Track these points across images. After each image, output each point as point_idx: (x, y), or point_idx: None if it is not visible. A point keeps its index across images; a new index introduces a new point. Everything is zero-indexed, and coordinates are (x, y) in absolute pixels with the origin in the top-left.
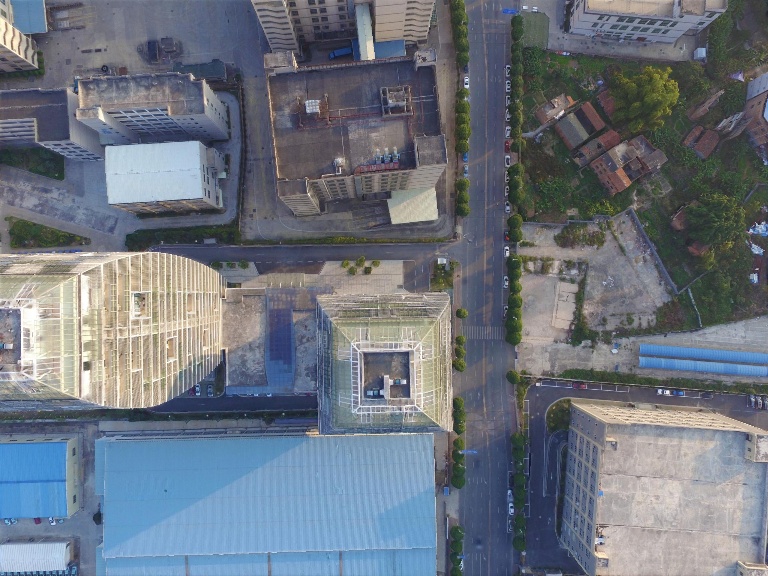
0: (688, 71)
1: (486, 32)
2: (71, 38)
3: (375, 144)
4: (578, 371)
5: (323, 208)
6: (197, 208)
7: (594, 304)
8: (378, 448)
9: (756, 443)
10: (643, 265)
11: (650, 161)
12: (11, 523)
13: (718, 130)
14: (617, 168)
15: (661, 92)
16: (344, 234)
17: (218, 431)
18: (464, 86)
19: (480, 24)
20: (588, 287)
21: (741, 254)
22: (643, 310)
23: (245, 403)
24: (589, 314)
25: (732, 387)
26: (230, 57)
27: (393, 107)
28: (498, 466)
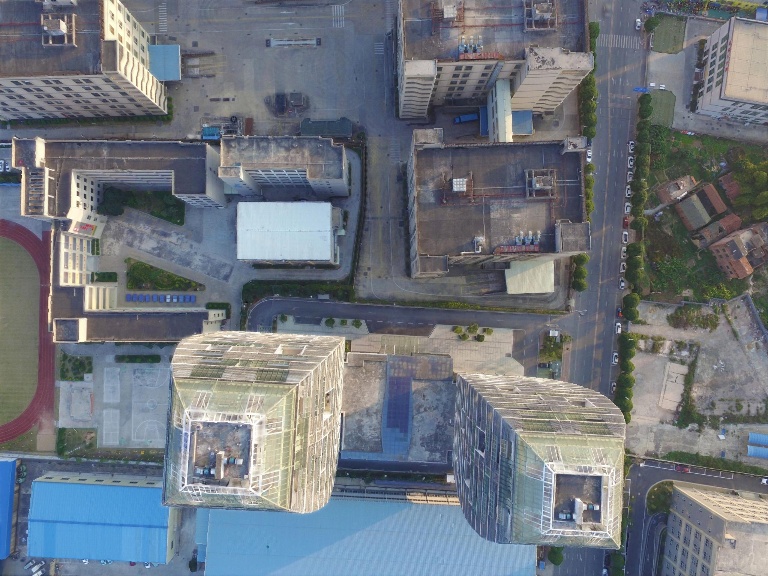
0: None
1: (611, 106)
2: (201, 86)
3: (516, 225)
4: (683, 454)
5: None
6: (314, 263)
7: (703, 387)
8: None
9: None
10: (755, 352)
11: None
12: (106, 563)
13: None
14: (742, 256)
15: None
16: (456, 299)
17: None
18: (586, 159)
19: (606, 98)
20: (698, 370)
21: None
22: (752, 397)
23: (346, 461)
24: (698, 397)
25: None
26: (355, 115)
27: (537, 190)
28: None
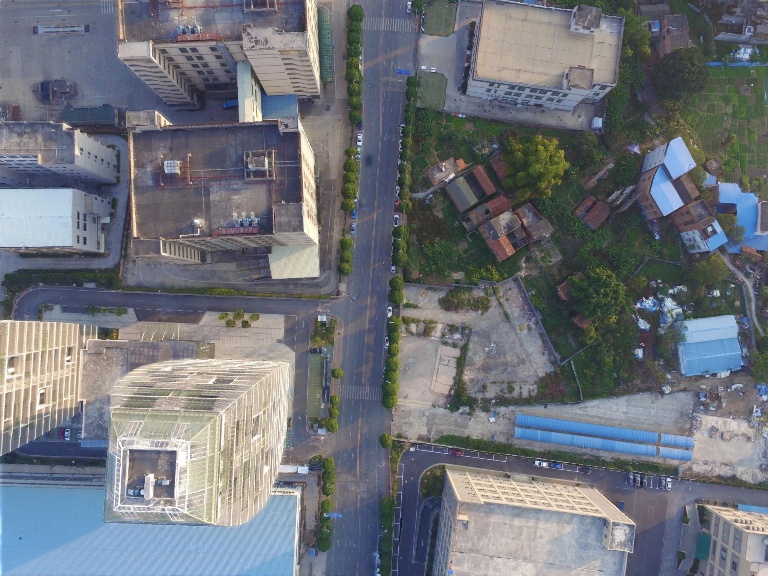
0: (582, 141)
1: (383, 90)
2: None
3: (236, 207)
4: (454, 438)
5: (204, 259)
6: (78, 251)
7: (475, 370)
8: None
9: (611, 531)
10: (527, 333)
11: (535, 231)
12: None
13: (608, 202)
14: (498, 237)
15: (544, 164)
16: (226, 285)
17: (86, 477)
18: (357, 143)
19: (377, 81)
20: (470, 353)
21: (627, 328)
22: (525, 379)
23: None
24: (469, 380)
25: (610, 463)
26: (124, 101)
27: (255, 171)
28: (368, 529)
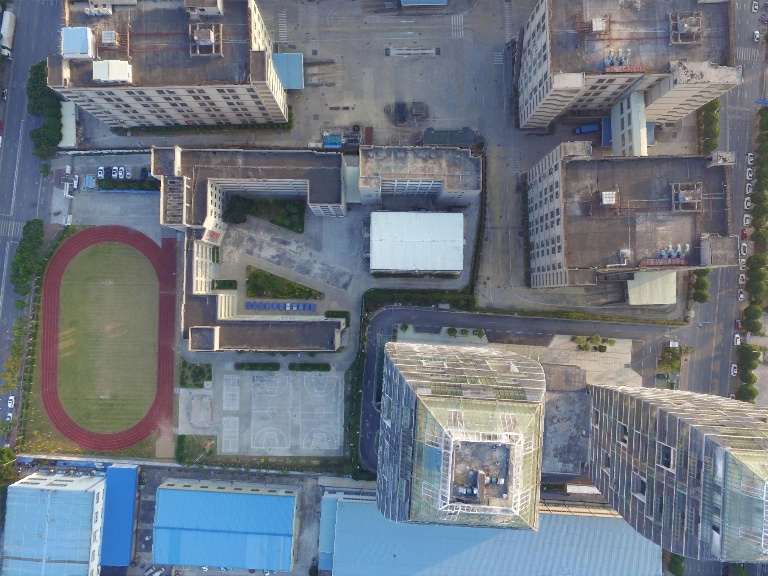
0: None
1: (730, 118)
2: (320, 94)
3: (661, 238)
4: None
5: None
6: None
7: None
8: (606, 530)
9: None
10: None
11: None
12: (226, 570)
13: None
14: None
15: None
16: (575, 309)
17: None
18: None
19: (724, 110)
20: None
21: None
22: None
23: None
24: None
25: None
26: (475, 124)
27: (684, 203)
28: None
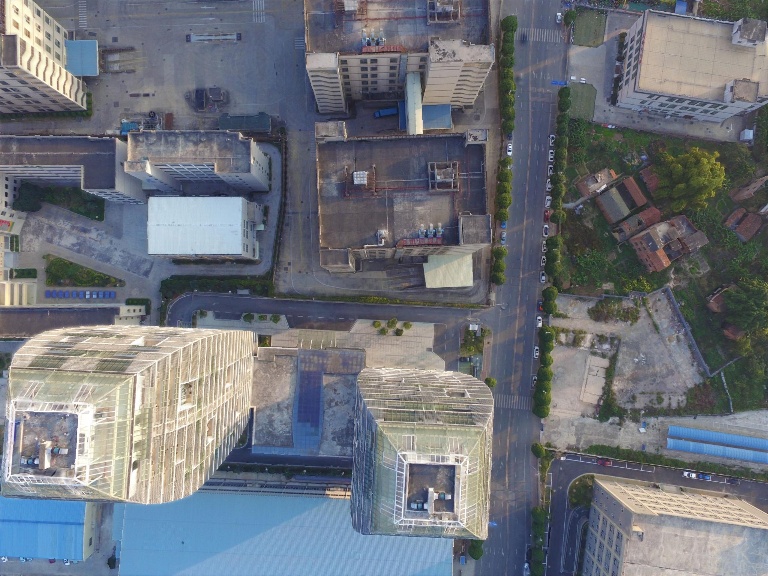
0: (734, 153)
1: (532, 100)
2: (121, 81)
3: (419, 217)
4: (604, 448)
5: (358, 267)
6: (233, 258)
7: (624, 381)
8: None
9: None
10: (676, 344)
11: (691, 242)
12: (26, 560)
13: (761, 214)
14: (657, 248)
15: (707, 176)
16: (377, 293)
17: (238, 482)
18: (507, 153)
19: (527, 92)
20: (619, 363)
21: None
22: (674, 390)
23: (267, 456)
24: (618, 390)
25: (760, 475)
26: (276, 109)
27: (440, 182)
28: (516, 538)
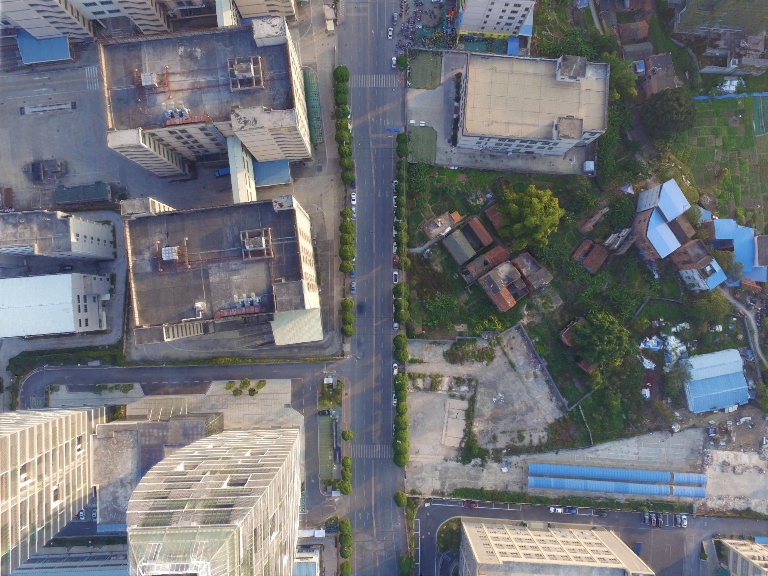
0: (575, 186)
1: (373, 147)
2: None
3: (236, 287)
4: (468, 490)
5: (207, 330)
6: None
7: (484, 421)
8: None
9: None
10: (534, 381)
11: (535, 280)
12: None
13: (605, 246)
14: (499, 290)
15: (539, 216)
16: (231, 353)
17: (103, 555)
18: (351, 202)
19: (367, 139)
20: (478, 404)
21: (632, 369)
22: (534, 427)
23: None
24: (479, 432)
25: (625, 505)
26: (116, 176)
27: (253, 250)
28: None
